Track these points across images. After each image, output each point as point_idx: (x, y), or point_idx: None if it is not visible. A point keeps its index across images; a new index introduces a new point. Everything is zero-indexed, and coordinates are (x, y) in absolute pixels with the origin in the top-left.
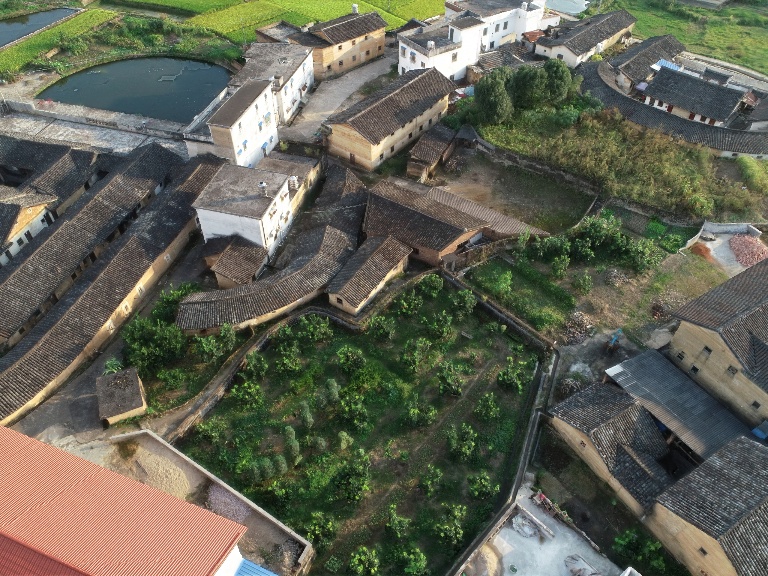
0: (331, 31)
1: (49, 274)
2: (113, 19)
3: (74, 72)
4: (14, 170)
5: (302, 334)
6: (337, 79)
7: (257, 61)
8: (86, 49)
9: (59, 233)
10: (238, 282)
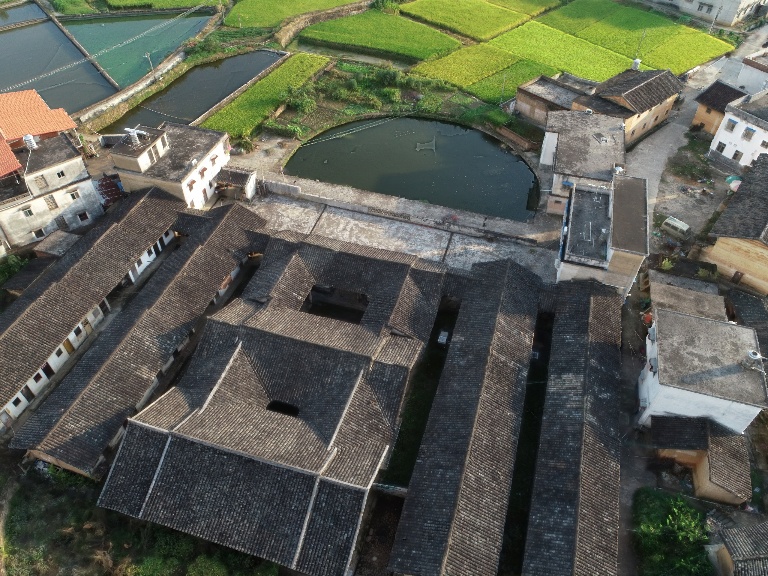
0: (632, 96)
1: (493, 484)
2: (327, 66)
3: (312, 137)
4: (323, 287)
5: None
6: (632, 153)
7: (569, 138)
8: (315, 106)
9: (480, 415)
10: (743, 497)
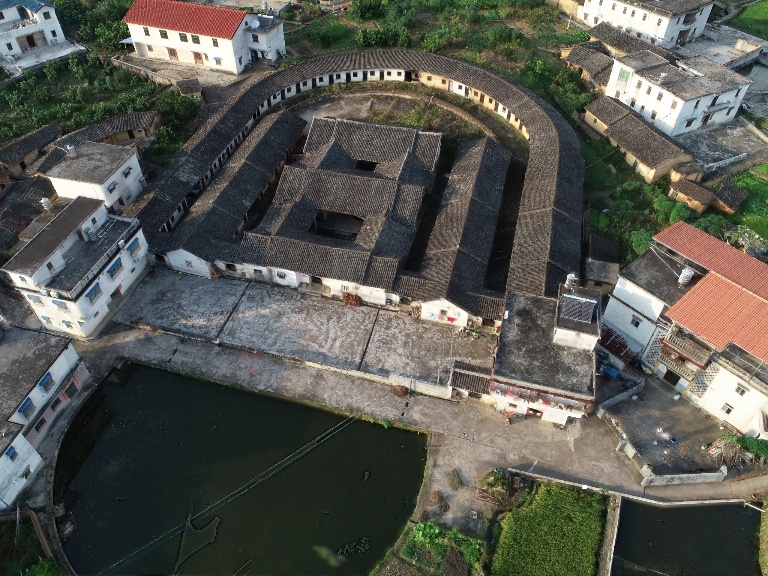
0: None
1: None
2: None
3: None
4: None
5: (88, 116)
6: None
7: (1, 407)
8: None
9: None
10: None
